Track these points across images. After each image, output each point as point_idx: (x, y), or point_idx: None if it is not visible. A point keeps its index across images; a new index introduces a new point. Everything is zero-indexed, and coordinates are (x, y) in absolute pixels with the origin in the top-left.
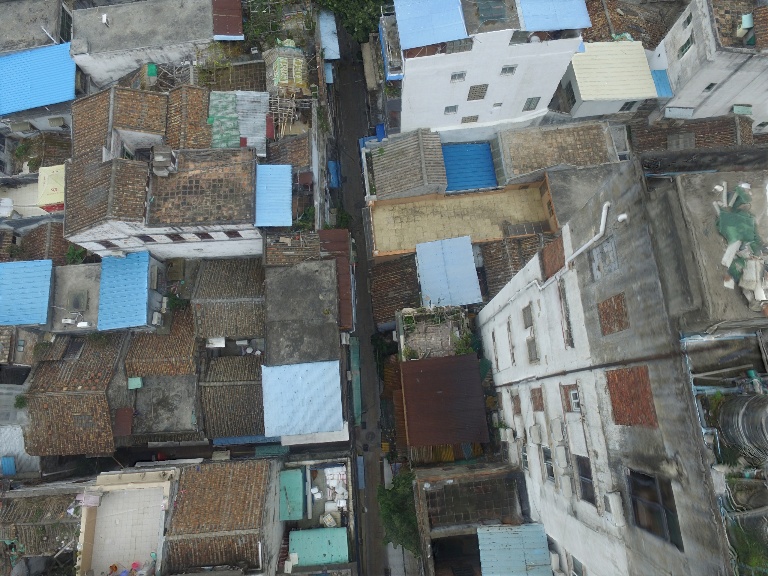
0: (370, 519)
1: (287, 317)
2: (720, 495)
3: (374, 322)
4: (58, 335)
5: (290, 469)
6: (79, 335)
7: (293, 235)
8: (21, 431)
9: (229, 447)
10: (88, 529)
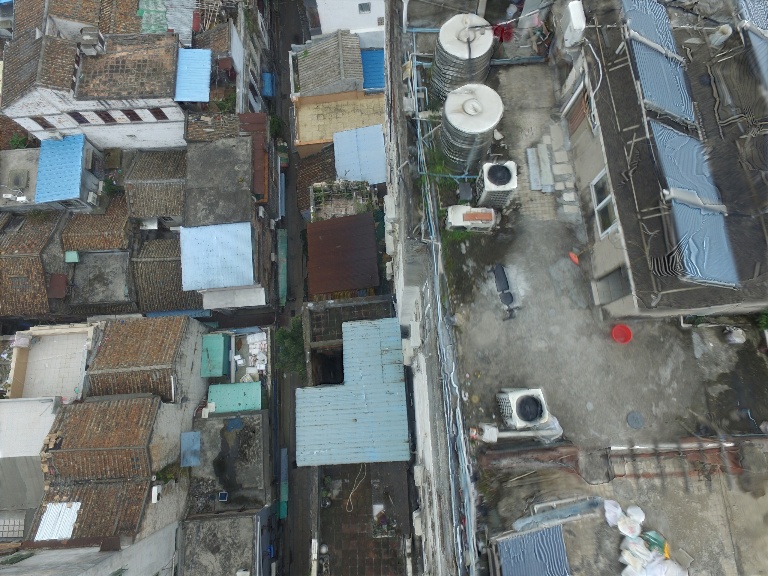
0: None
1: (205, 185)
2: (406, 111)
3: (298, 210)
4: (1, 212)
5: (213, 333)
6: (21, 213)
7: (214, 115)
8: None
9: None
10: (18, 368)
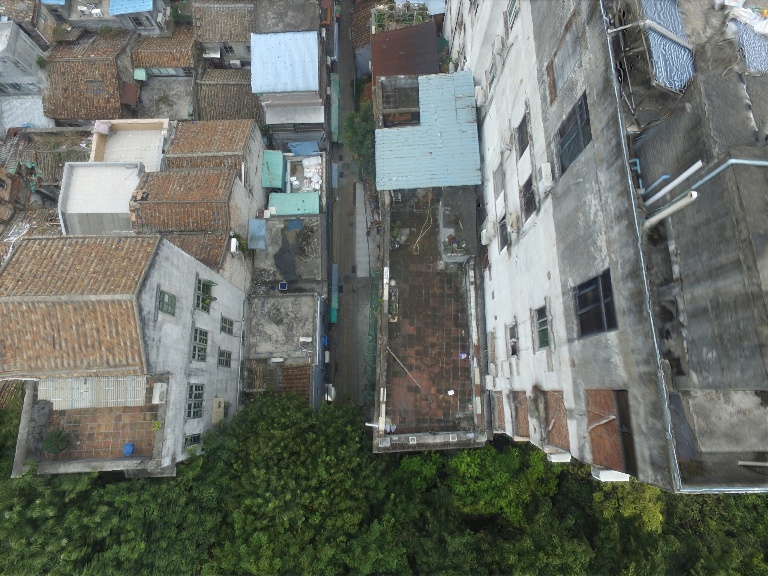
0: (342, 229)
1: None
2: None
3: (353, 50)
4: (74, 27)
5: (272, 150)
6: (92, 32)
7: None
8: (40, 103)
9: None
10: (98, 153)
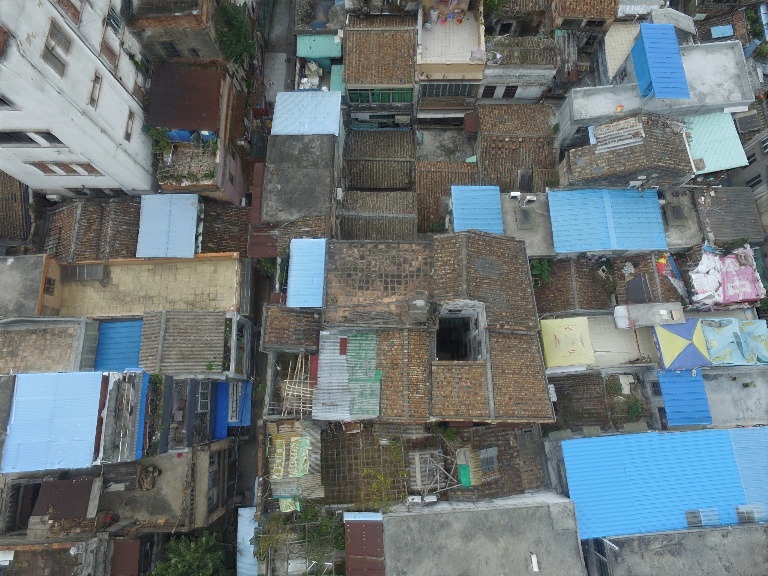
0: None
1: (312, 171)
2: None
3: None
4: None
5: None
6: None
7: None
8: None
9: (397, 126)
10: None
